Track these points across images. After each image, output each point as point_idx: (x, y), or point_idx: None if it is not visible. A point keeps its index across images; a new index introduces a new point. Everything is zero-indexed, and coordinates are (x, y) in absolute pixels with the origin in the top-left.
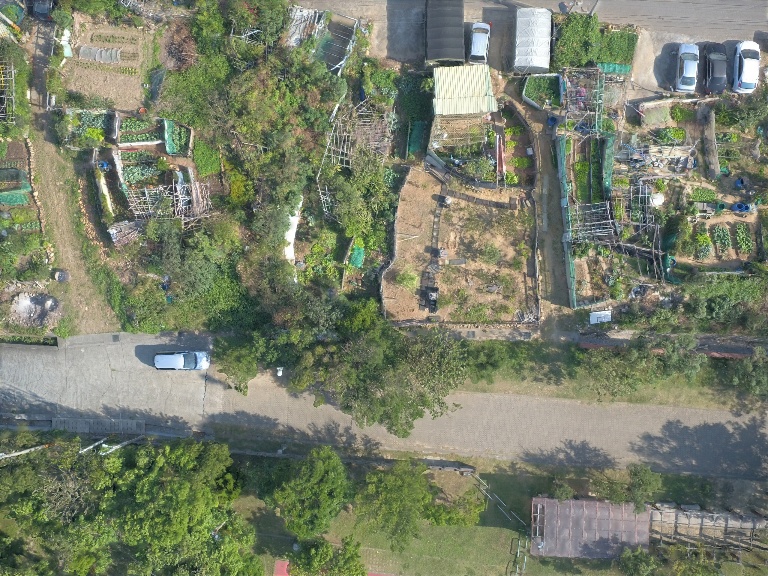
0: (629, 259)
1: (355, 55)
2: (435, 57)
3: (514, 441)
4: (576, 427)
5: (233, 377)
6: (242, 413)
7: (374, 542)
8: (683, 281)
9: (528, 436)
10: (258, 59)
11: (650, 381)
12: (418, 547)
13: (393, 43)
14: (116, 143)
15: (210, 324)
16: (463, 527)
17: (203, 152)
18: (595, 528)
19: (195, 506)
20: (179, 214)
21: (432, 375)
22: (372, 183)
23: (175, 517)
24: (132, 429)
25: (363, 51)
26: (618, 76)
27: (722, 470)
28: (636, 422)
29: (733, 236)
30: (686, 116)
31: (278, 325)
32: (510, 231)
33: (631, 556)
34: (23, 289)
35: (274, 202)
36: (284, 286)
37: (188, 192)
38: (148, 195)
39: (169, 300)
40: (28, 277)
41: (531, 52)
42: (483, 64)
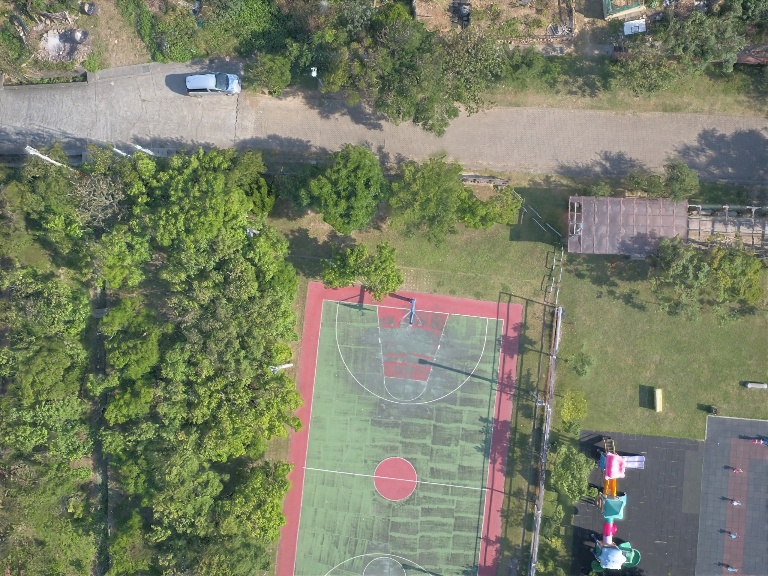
0: None
1: None
2: None
3: (549, 154)
4: (611, 138)
5: (267, 80)
6: (274, 136)
7: (408, 260)
8: None
9: (563, 149)
10: None
11: (688, 69)
12: (452, 264)
13: None
14: None
15: (241, 48)
16: (498, 242)
17: None
18: (633, 224)
19: (231, 197)
20: None
21: (469, 63)
22: None
23: (211, 207)
24: None
25: None
26: None
27: (759, 177)
28: (671, 131)
29: None
30: None
31: (311, 31)
32: None
33: (670, 245)
34: (52, 26)
35: None
36: None
37: None
38: None
39: (200, 26)
40: (58, 8)
41: None
42: None
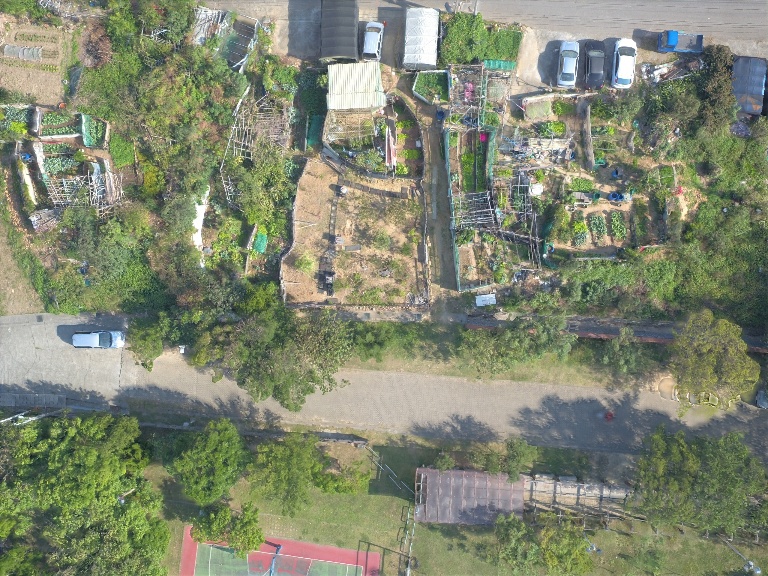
0: (512, 245)
1: (255, 53)
2: (328, 55)
3: (405, 416)
4: (462, 403)
5: (140, 354)
6: (154, 389)
7: (275, 509)
8: (558, 266)
9: (418, 411)
10: (166, 57)
11: (523, 359)
12: (316, 514)
13: (294, 41)
14: (37, 136)
15: (125, 306)
16: (357, 496)
17: (118, 144)
18: (474, 496)
19: (101, 473)
20: (94, 203)
21: (319, 353)
22: (272, 174)
23: (82, 482)
24: (54, 403)
25: (265, 49)
26: (504, 72)
27: (598, 444)
28: (518, 399)
29: (609, 224)
30: (566, 110)
31: (182, 306)
32: (400, 219)
33: (504, 522)
34: None
35: (182, 191)
36: (189, 270)
37: (102, 182)
38: (66, 185)
39: (87, 283)
40: None
41: (419, 50)
42: (375, 61)
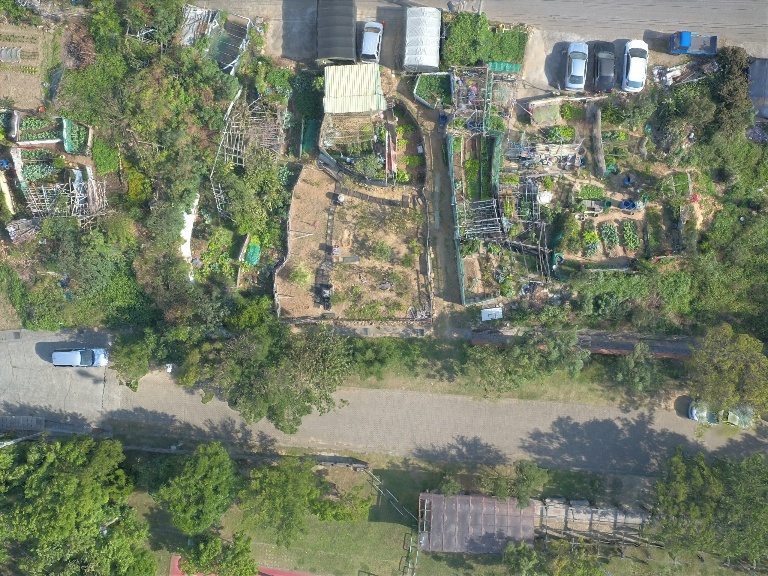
0: (519, 256)
1: (248, 54)
2: (325, 56)
3: (407, 437)
4: (468, 423)
5: (124, 374)
6: (140, 410)
7: (269, 537)
8: (568, 278)
9: (420, 432)
10: (153, 58)
11: (533, 377)
12: (312, 542)
13: (288, 42)
14: (15, 141)
15: (108, 321)
16: (357, 523)
17: (102, 150)
18: (481, 523)
19: (81, 501)
20: (76, 212)
21: (316, 371)
22: (266, 181)
23: (61, 512)
24: (32, 426)
25: (258, 50)
26: (509, 75)
27: (611, 466)
28: (527, 418)
29: (621, 233)
30: (575, 114)
31: (170, 322)
32: (401, 229)
33: (514, 551)
34: None
35: (170, 200)
36: (177, 283)
37: (84, 190)
38: (45, 193)
39: (68, 297)
40: None
41: (420, 51)
42: (374, 63)
